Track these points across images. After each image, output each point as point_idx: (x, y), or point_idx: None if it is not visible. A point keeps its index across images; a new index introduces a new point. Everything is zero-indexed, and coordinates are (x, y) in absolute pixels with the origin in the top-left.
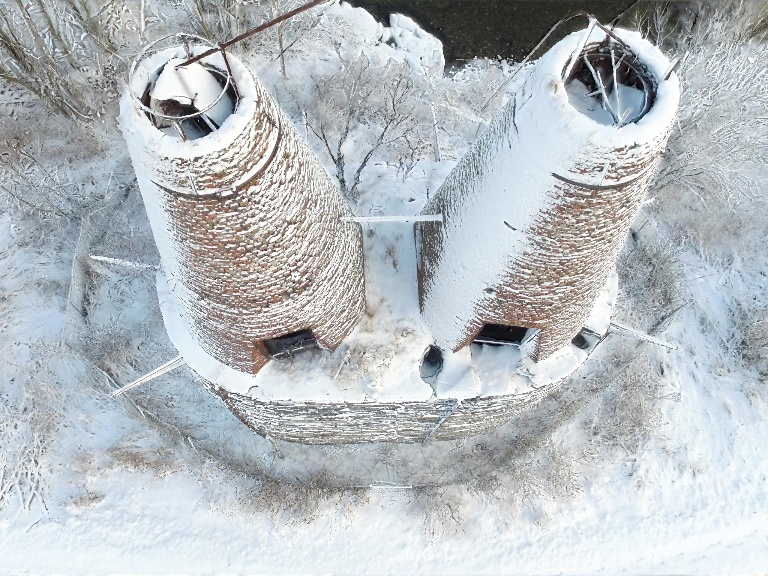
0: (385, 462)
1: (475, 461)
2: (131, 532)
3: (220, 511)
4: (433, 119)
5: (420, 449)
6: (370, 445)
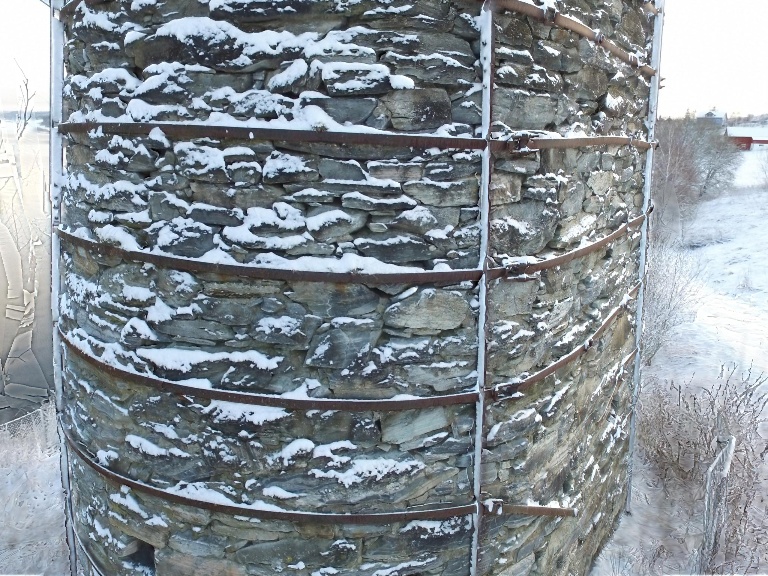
0: (648, 569)
1: (677, 491)
2: None
3: None
4: None
5: (634, 523)
6: (600, 571)
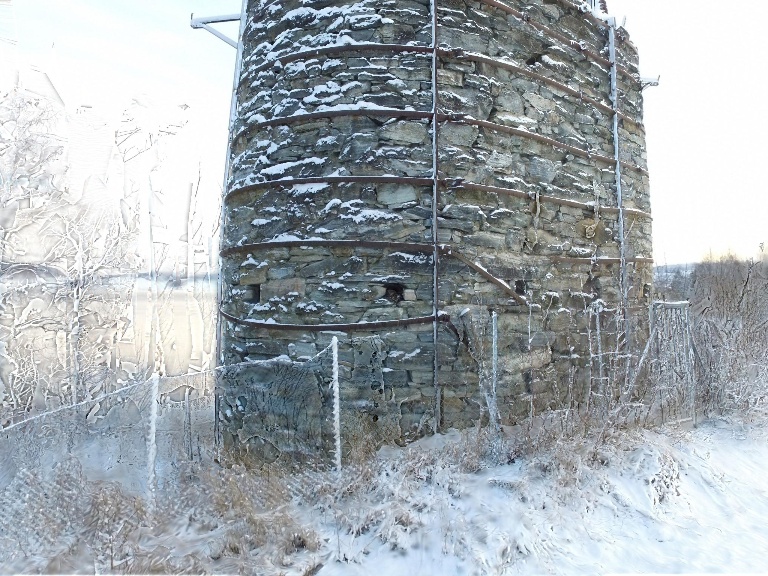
0: None
1: None
2: None
3: (515, 560)
4: None
5: None
6: None
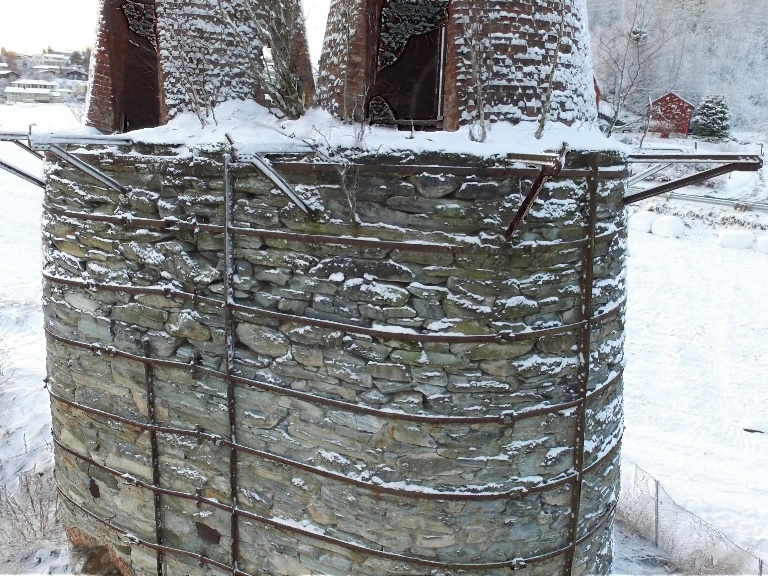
0: None
1: None
2: (764, 531)
3: None
4: (63, 137)
5: None
6: None
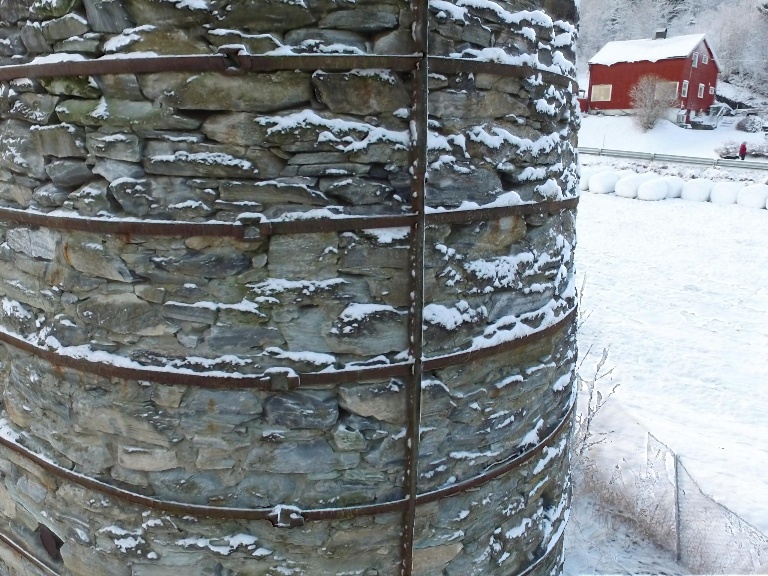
0: None
1: None
2: None
3: None
4: None
5: None
6: None
